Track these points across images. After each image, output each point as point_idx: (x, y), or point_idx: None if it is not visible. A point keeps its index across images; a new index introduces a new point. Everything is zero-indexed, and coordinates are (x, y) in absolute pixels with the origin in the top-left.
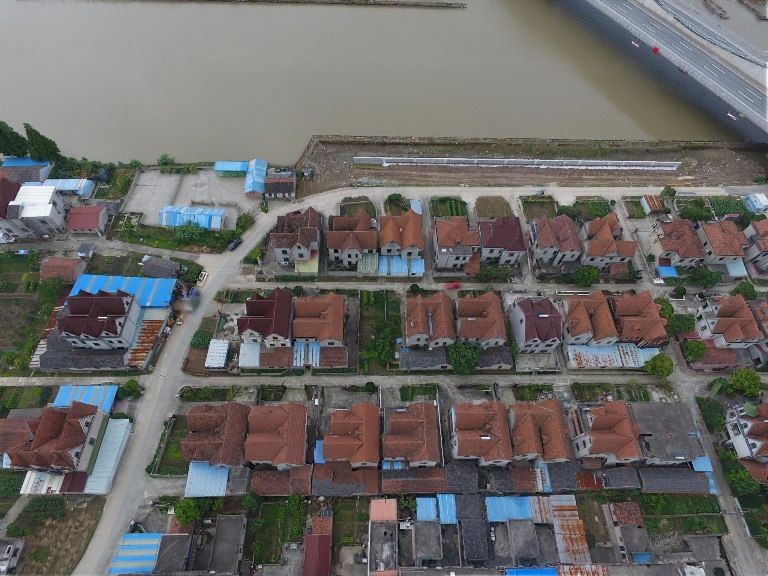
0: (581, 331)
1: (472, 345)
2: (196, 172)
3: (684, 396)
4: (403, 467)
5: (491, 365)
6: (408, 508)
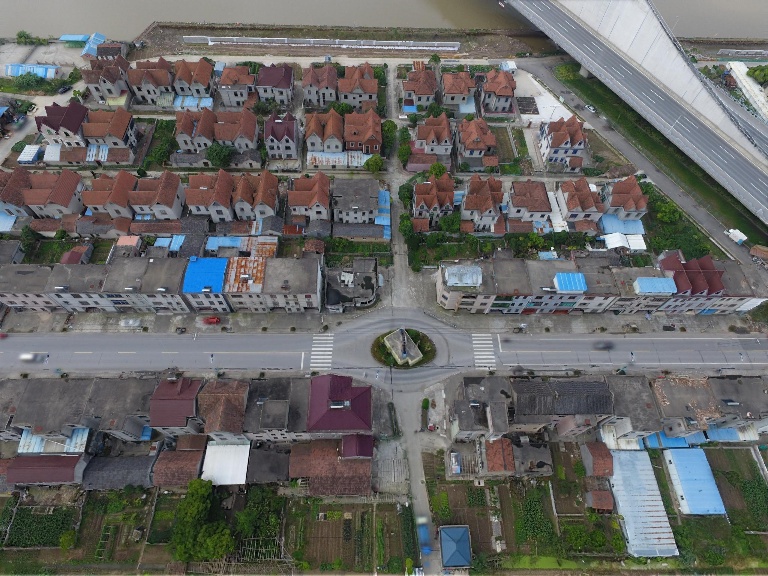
0: (309, 134)
1: (225, 145)
2: (47, 44)
3: (394, 187)
4: (151, 218)
5: (242, 162)
6: (149, 243)
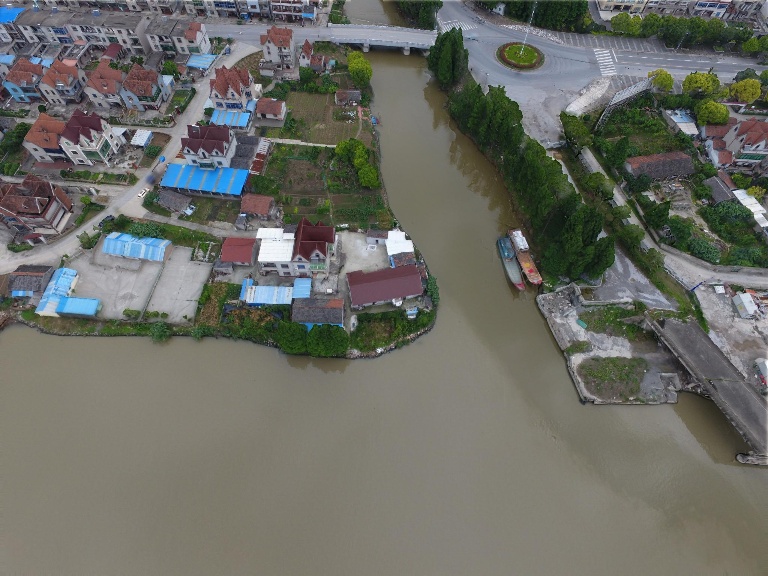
0: None
1: None
2: None
3: None
4: None
5: None
6: None
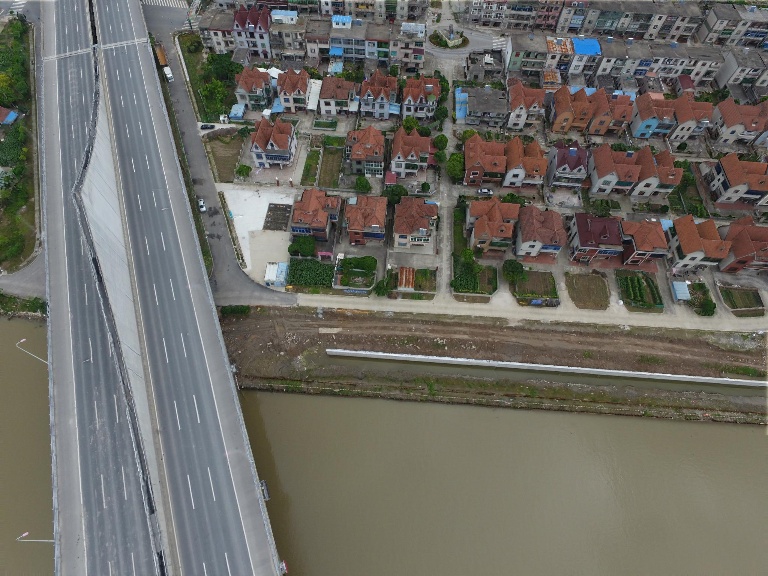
0: None
1: None
2: None
3: (449, 133)
4: None
5: None
6: None
